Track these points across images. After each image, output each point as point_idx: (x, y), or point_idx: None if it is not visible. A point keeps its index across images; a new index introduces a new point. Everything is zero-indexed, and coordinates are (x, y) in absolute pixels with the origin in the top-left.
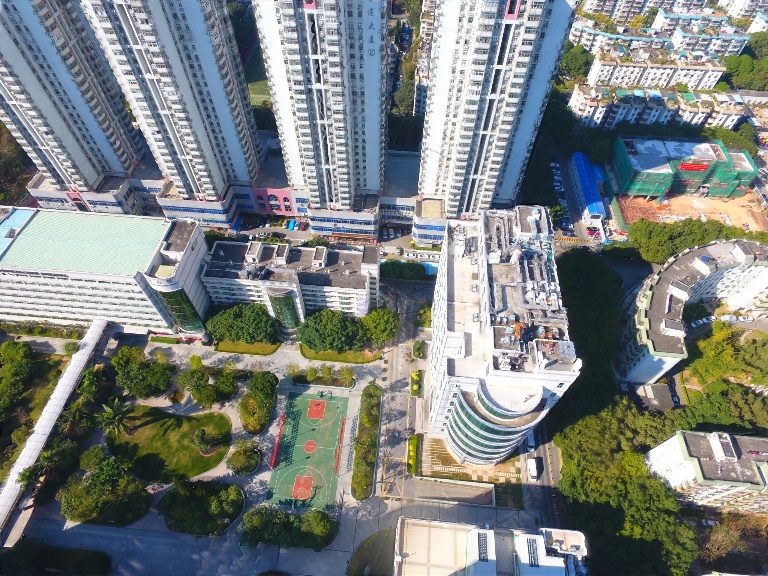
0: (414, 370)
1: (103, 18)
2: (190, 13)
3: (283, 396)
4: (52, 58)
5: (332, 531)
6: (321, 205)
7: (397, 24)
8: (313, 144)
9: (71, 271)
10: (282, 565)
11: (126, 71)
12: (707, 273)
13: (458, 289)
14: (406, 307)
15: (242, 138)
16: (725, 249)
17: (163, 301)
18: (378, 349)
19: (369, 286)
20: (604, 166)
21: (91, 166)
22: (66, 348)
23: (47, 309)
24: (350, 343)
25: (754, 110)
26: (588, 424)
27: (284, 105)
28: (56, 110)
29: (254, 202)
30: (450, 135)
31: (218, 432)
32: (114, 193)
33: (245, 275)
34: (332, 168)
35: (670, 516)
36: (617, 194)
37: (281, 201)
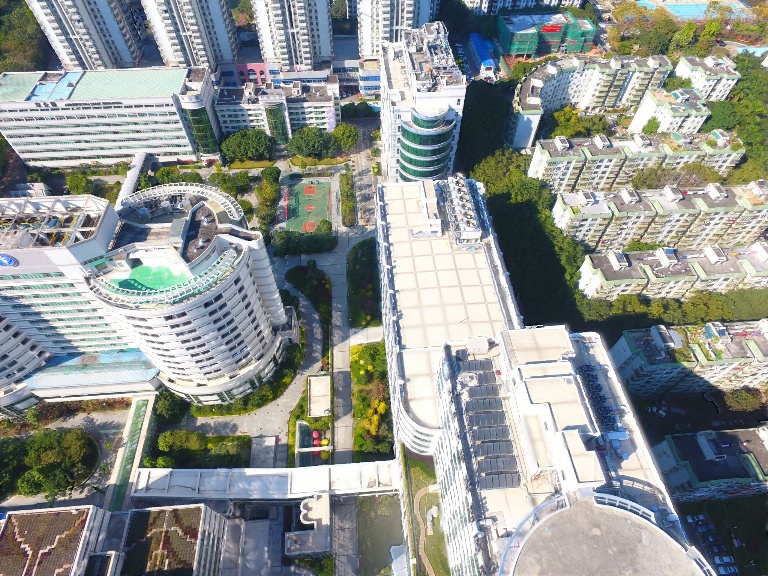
0: (373, 163)
1: None
2: None
3: (285, 186)
4: None
5: (334, 238)
6: (290, 68)
7: None
8: (281, 11)
9: (125, 97)
10: (304, 263)
11: None
12: (555, 73)
13: (393, 74)
14: (362, 133)
15: (226, 19)
16: (568, 62)
17: (190, 123)
18: (346, 156)
19: (334, 107)
20: (493, 39)
21: (108, 56)
22: (122, 167)
23: (100, 147)
24: (326, 148)
25: (599, 2)
26: (488, 162)
27: None
28: (83, 4)
29: (237, 78)
30: None
31: (243, 208)
32: None
33: (246, 101)
34: (296, 31)
35: (536, 186)
36: (503, 55)
37: (258, 75)
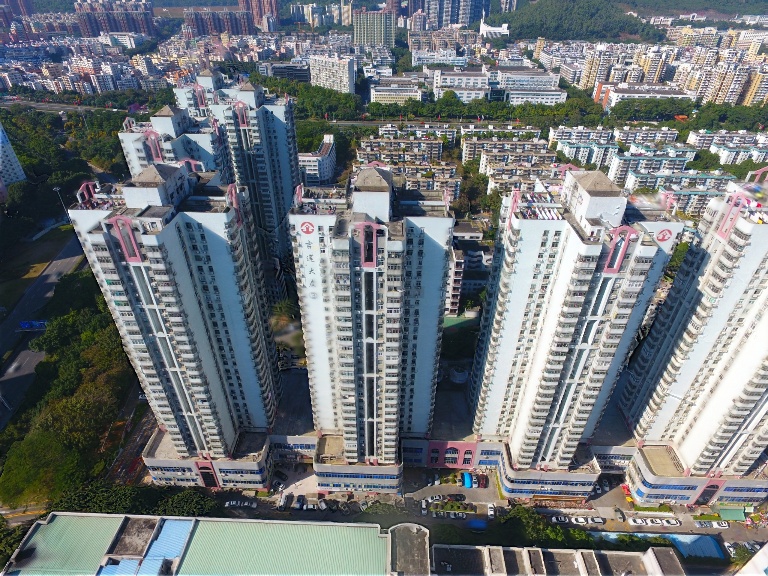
0: None
1: (343, 286)
2: (429, 270)
3: None
4: (233, 316)
5: None
6: None
7: (494, 228)
8: None
9: None
10: None
11: (344, 337)
12: None
13: None
14: None
15: None
16: None
17: None
18: None
19: None
20: None
21: (231, 425)
22: None
23: None
24: None
25: None
26: None
27: (505, 356)
28: (216, 370)
29: (425, 456)
30: (702, 381)
31: None
32: (256, 458)
33: None
34: (562, 427)
35: None
36: None
37: (461, 454)
